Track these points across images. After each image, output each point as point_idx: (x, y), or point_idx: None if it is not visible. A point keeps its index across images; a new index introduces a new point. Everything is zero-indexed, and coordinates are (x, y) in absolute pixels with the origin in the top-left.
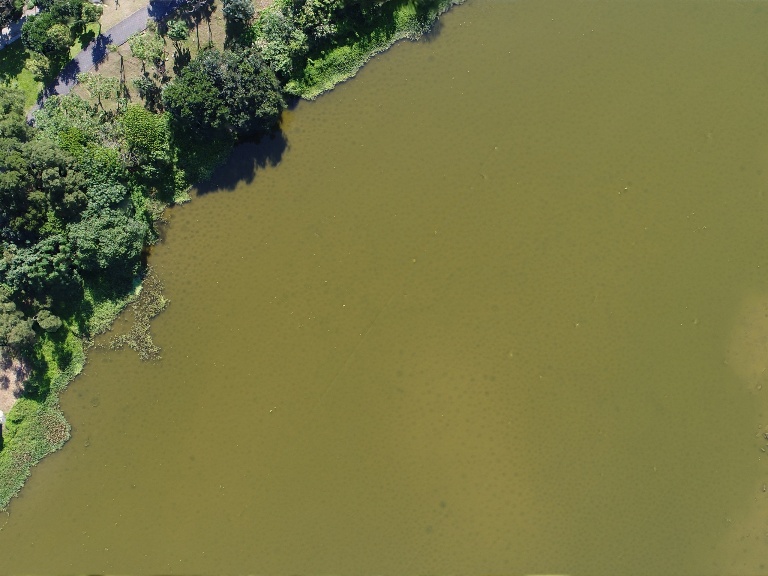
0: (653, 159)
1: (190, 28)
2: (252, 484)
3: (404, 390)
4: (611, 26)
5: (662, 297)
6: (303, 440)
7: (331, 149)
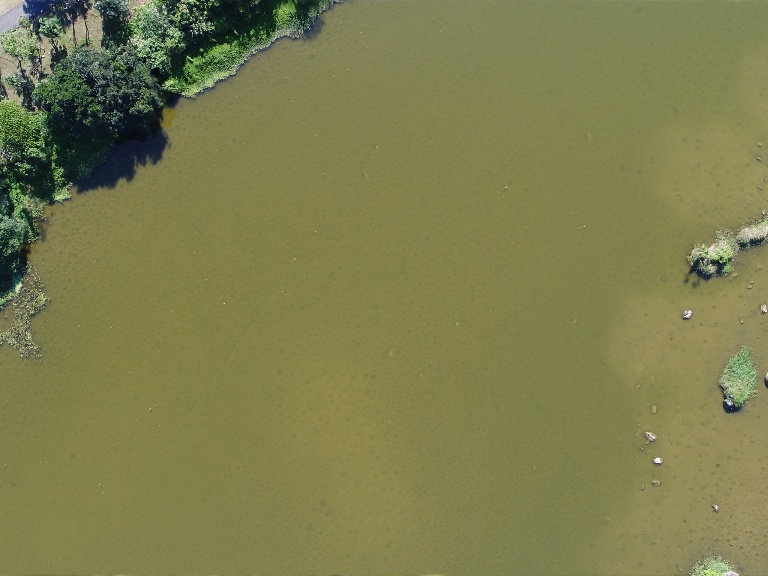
0: (533, 158)
1: (66, 25)
2: (132, 482)
3: (284, 388)
4: (491, 25)
5: (542, 296)
6: (183, 438)
7: (212, 147)
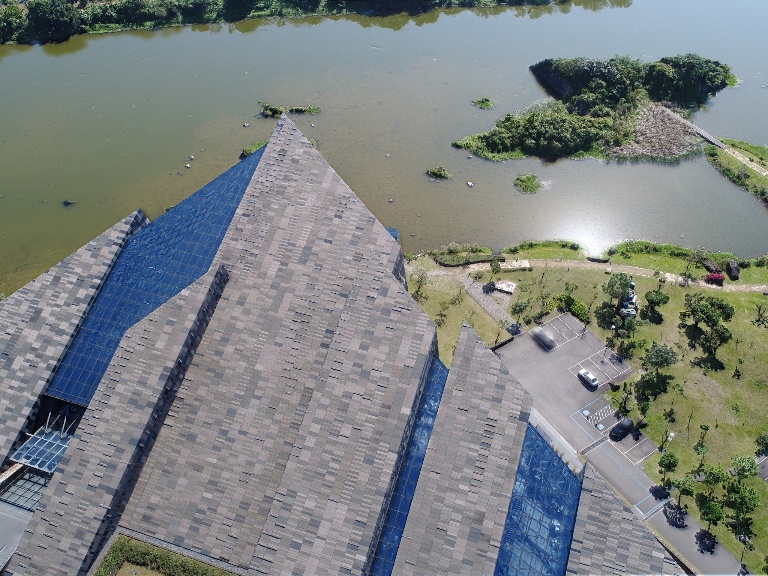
0: None
1: None
2: None
3: (33, 106)
4: (229, 41)
5: None
6: None
7: None
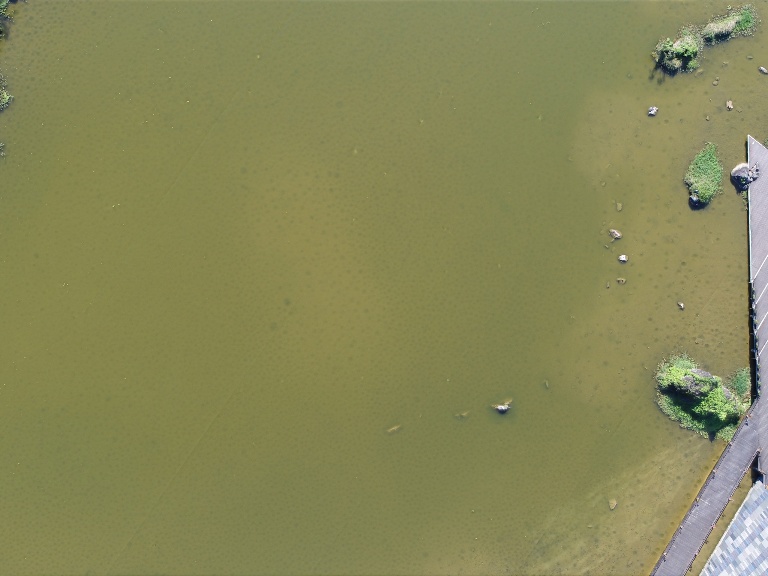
0: None
1: None
2: (96, 281)
3: (248, 187)
4: None
5: (506, 93)
6: (147, 237)
7: None
